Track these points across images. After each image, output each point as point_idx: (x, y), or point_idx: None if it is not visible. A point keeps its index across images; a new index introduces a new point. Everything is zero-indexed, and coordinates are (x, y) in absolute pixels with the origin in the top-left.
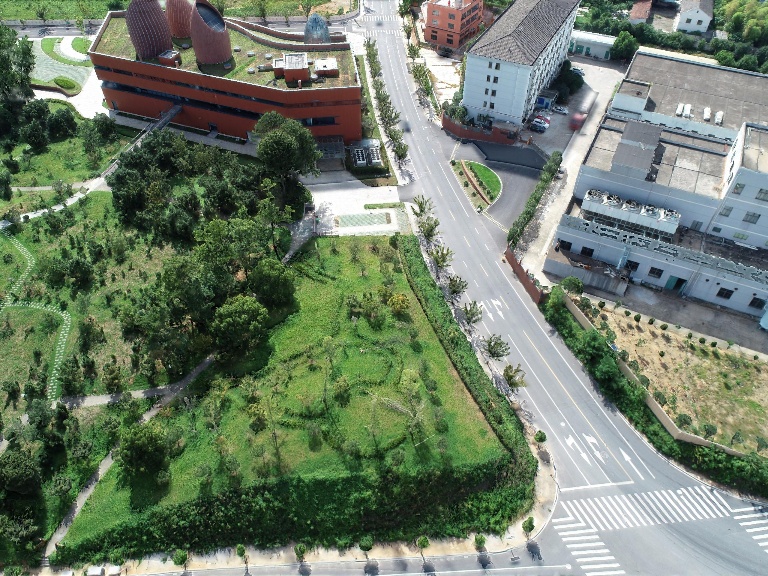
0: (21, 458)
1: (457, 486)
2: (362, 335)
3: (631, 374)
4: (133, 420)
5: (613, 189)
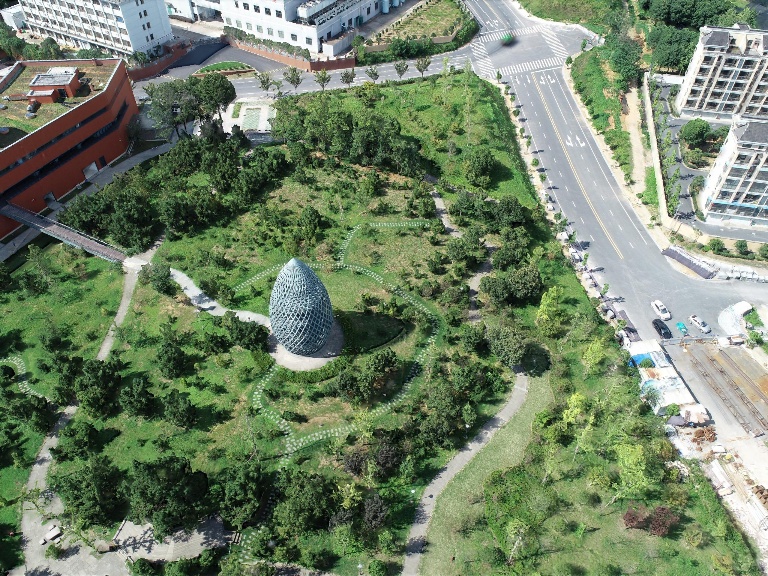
0: None
1: (485, 86)
2: (392, 101)
3: (419, 40)
4: (451, 190)
5: (298, 3)
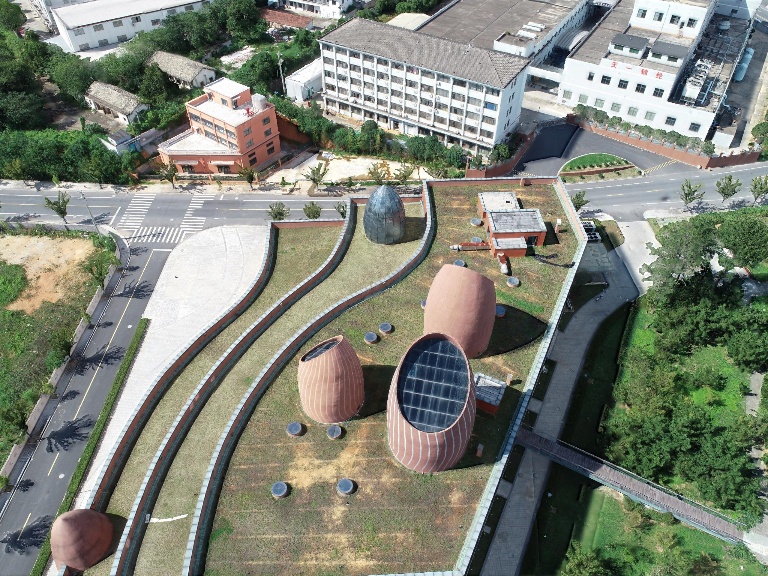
0: None
1: None
2: None
3: None
4: None
5: None
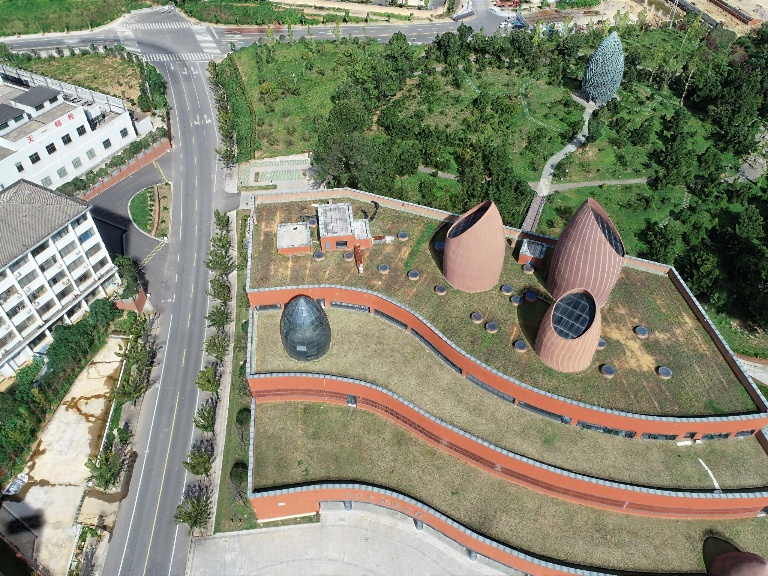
0: (447, 35)
1: None
2: None
3: None
4: None
5: None
